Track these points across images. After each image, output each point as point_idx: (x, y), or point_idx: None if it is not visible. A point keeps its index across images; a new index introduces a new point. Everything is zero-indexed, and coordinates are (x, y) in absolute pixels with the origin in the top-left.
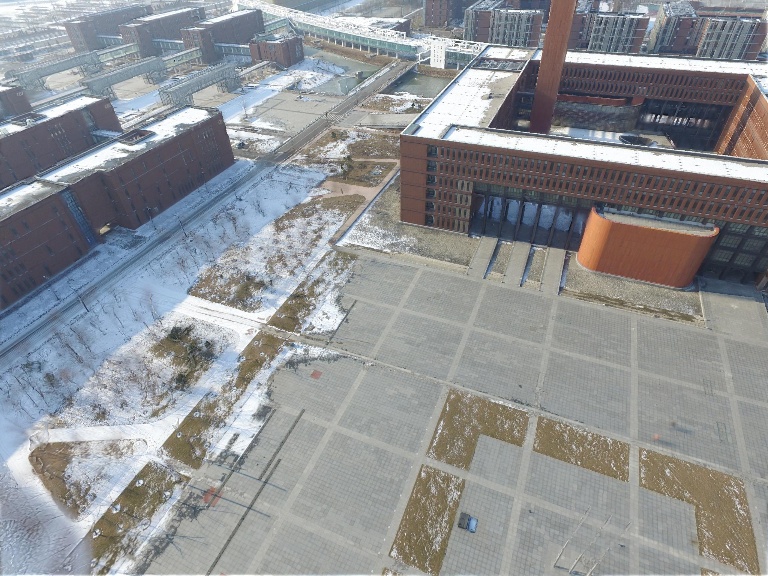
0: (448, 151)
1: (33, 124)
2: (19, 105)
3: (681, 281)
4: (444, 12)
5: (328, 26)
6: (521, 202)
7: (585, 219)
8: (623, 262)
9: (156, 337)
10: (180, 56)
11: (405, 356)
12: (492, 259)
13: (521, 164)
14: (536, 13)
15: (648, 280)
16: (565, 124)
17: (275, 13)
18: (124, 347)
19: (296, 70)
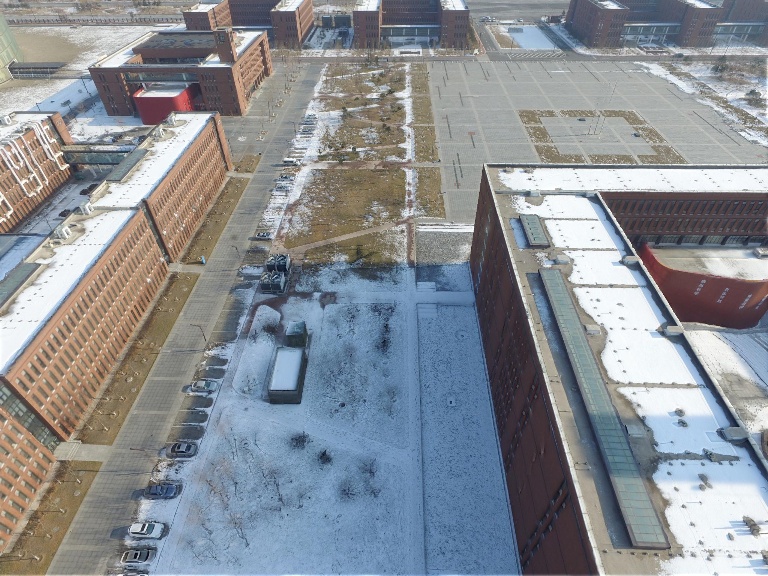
0: None
1: None
2: None
3: None
4: None
5: None
6: None
7: None
8: None
9: None
10: None
11: None
12: None
13: None
14: None
15: None
16: None
17: None
18: None
19: None
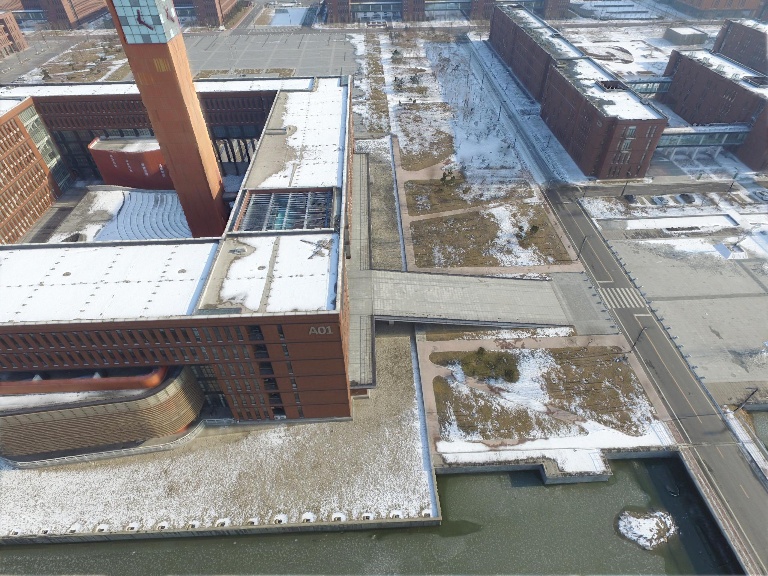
0: None
1: (732, 78)
2: None
3: None
4: None
5: None
6: None
7: None
8: None
9: None
10: None
11: None
12: None
13: None
14: None
15: None
16: None
17: None
18: None
19: None
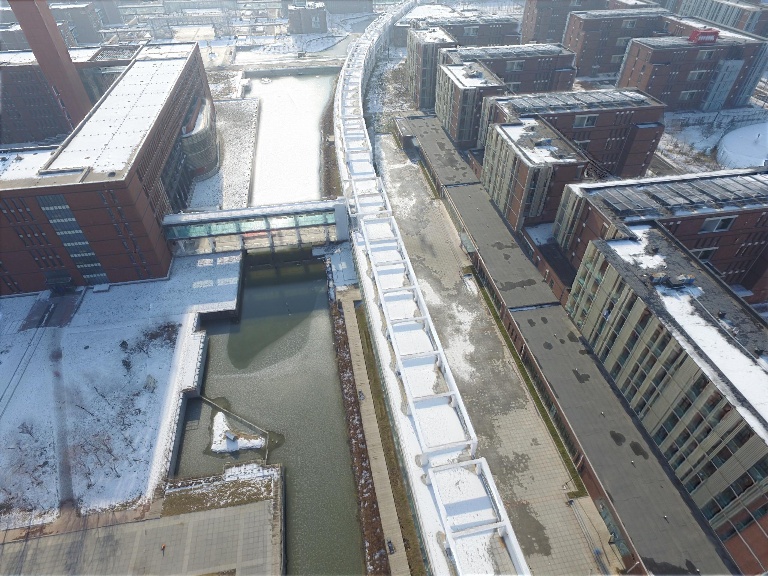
0: None
1: None
2: (106, 3)
3: None
4: (533, 28)
5: None
6: None
7: None
8: None
9: None
10: (258, 3)
11: None
12: None
13: None
14: None
15: None
16: None
17: None
18: None
19: (291, 37)
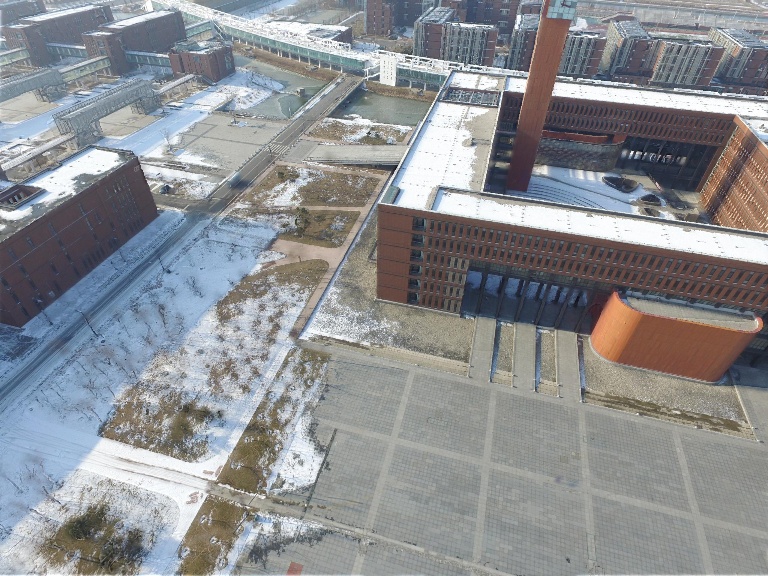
0: (439, 225)
1: None
2: None
3: (715, 375)
4: (387, 20)
5: (261, 32)
6: (526, 282)
7: (603, 302)
8: (650, 355)
9: (49, 541)
10: (82, 67)
11: (413, 522)
12: (494, 350)
13: (531, 243)
14: (490, 29)
15: (677, 373)
16: (542, 162)
17: (197, 14)
18: (0, 549)
19: (227, 85)
